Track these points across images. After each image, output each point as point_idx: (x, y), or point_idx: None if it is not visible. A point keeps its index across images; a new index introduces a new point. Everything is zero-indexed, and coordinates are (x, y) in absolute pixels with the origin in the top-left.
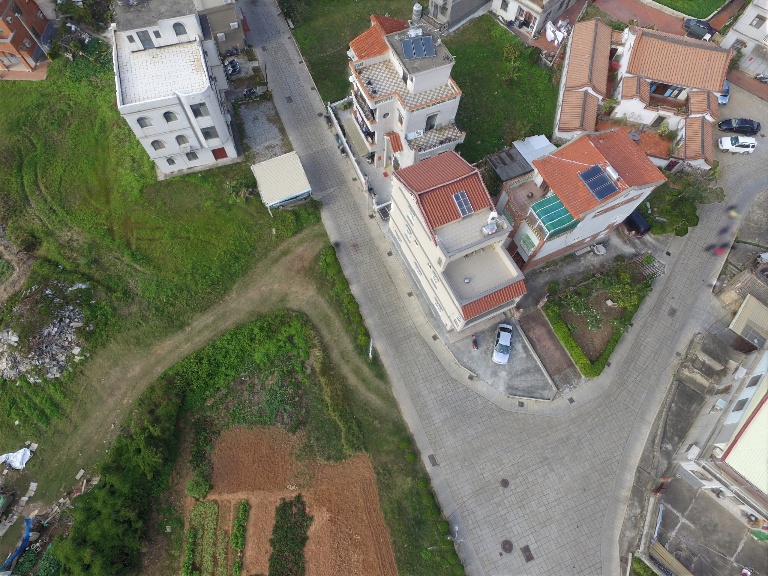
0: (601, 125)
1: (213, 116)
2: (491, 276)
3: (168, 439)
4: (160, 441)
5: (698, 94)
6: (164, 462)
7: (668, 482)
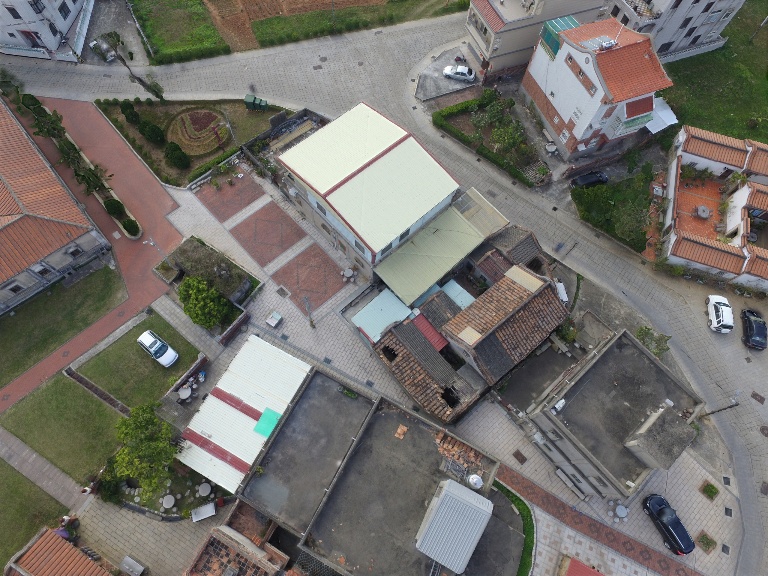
0: (713, 192)
1: None
2: (507, 17)
3: None
4: None
5: None
6: None
7: None
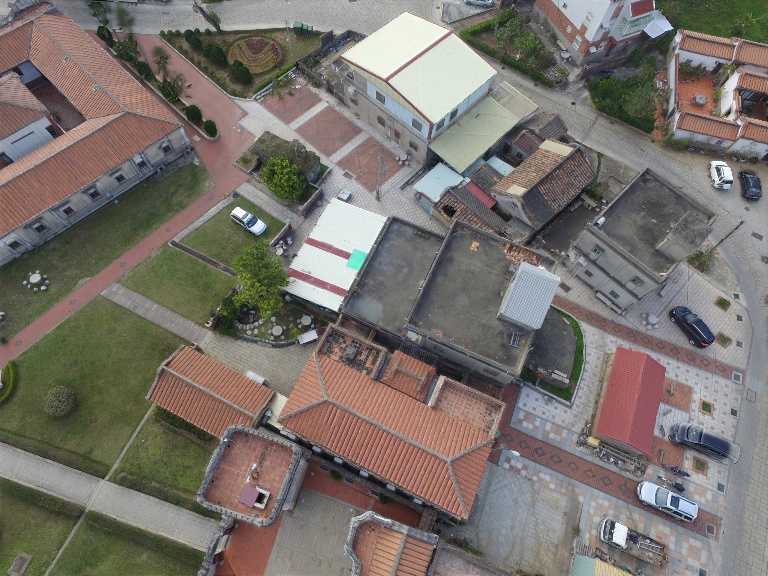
0: (707, 85)
1: None
2: None
3: None
4: None
5: None
6: None
7: None
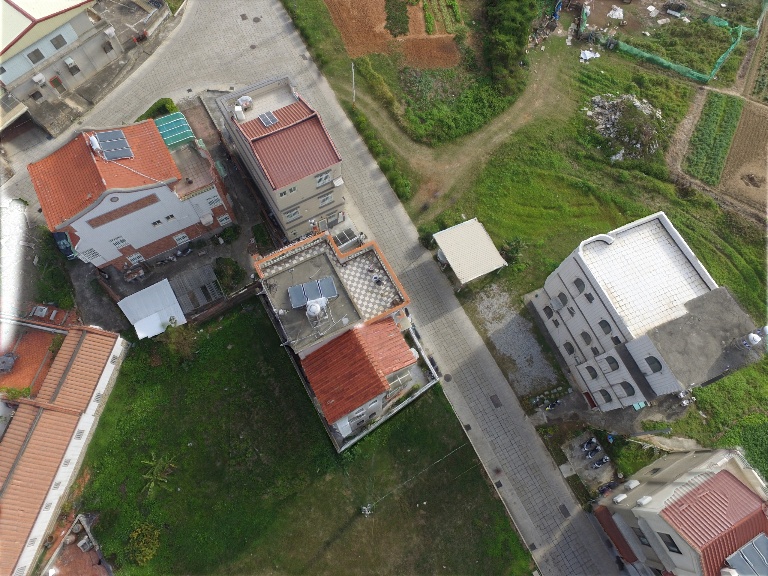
0: None
1: None
2: None
3: None
4: None
5: None
6: None
7: (134, 36)
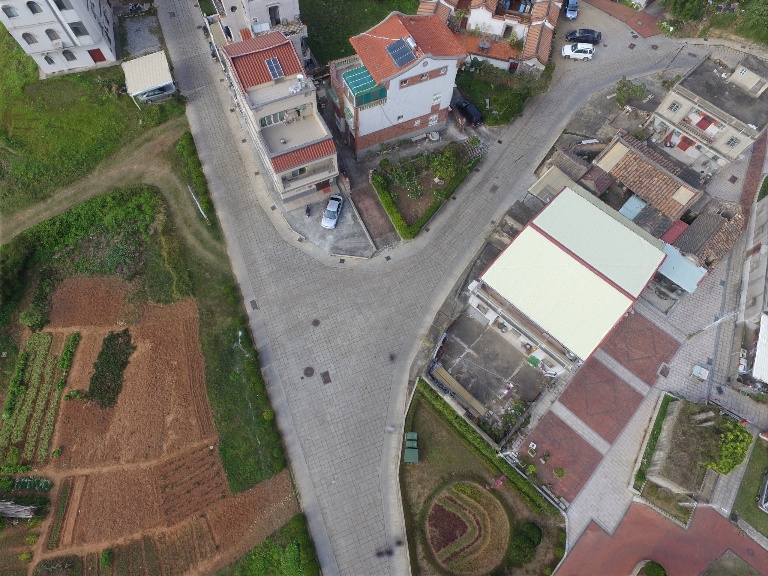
0: (458, 37)
1: (78, 10)
2: (307, 139)
3: (12, 281)
4: (3, 281)
5: (541, 4)
6: (7, 300)
7: (456, 317)
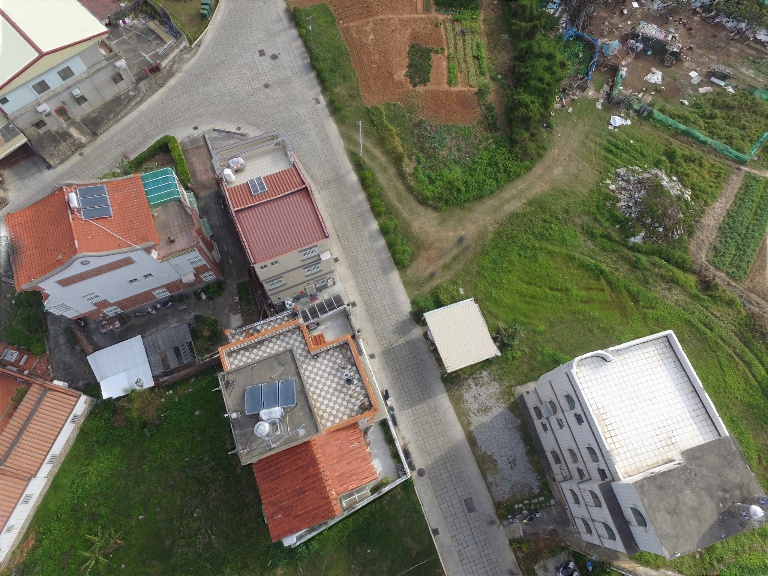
0: None
1: None
2: None
3: None
4: None
5: None
6: None
7: (147, 67)
